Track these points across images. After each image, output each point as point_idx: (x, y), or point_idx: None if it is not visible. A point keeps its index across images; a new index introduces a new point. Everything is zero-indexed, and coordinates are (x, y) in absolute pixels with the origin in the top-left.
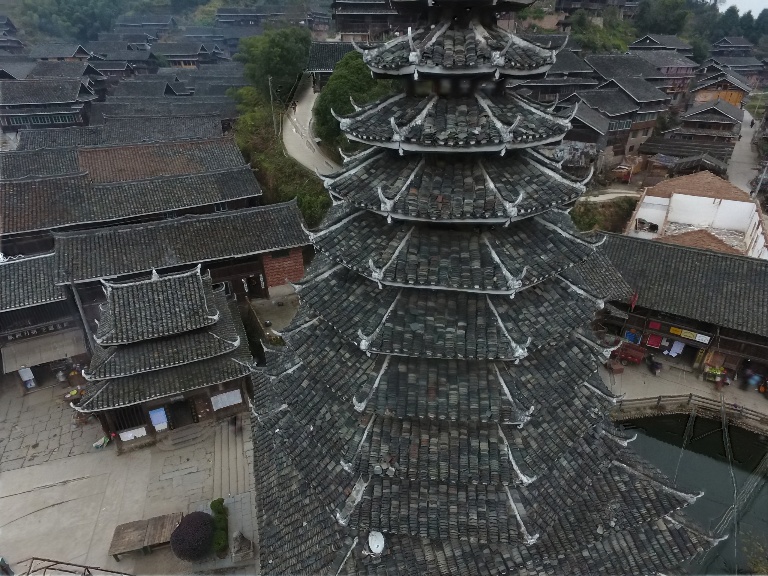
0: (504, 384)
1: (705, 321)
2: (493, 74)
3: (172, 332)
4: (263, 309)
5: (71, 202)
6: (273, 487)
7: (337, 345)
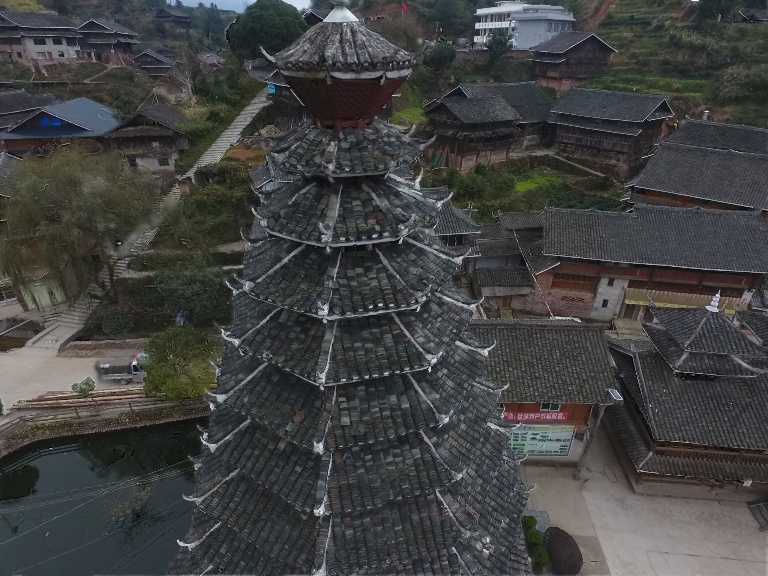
0: None
1: None
2: None
3: None
4: None
5: None
6: None
7: None
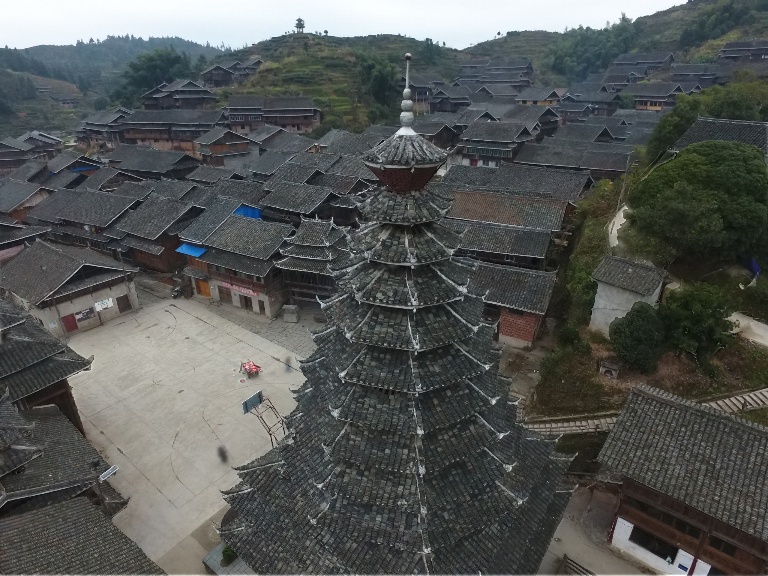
0: None
1: None
2: None
3: None
4: None
5: None
6: None
7: None
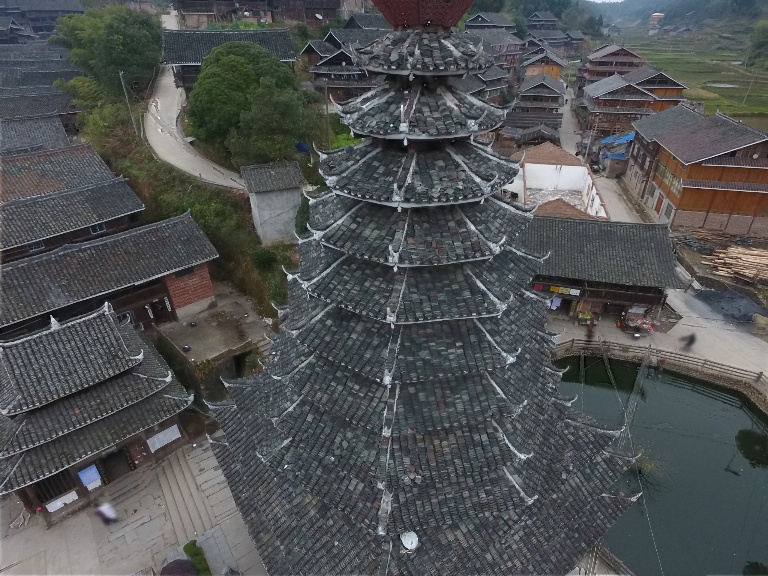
0: (496, 385)
1: (576, 278)
2: (469, 137)
3: (92, 383)
4: (175, 333)
5: None
6: (280, 517)
7: (343, 379)
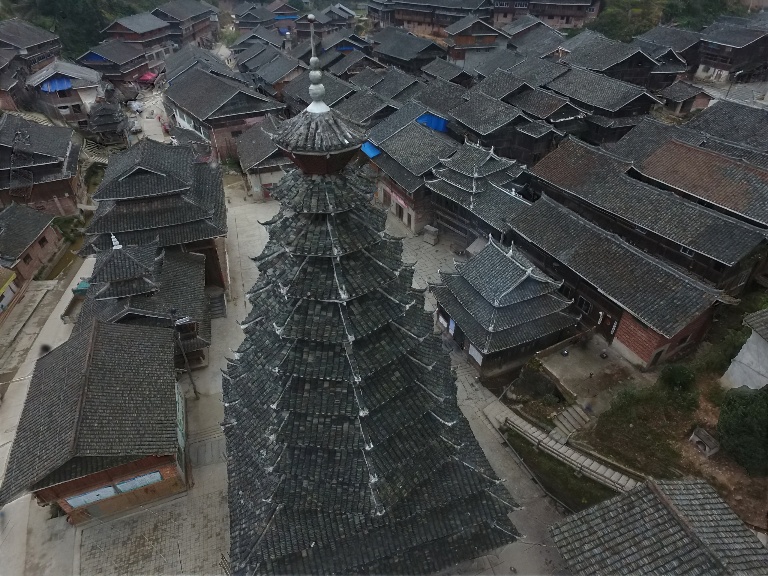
0: None
1: None
2: None
3: (477, 289)
4: (590, 345)
5: (594, 179)
6: None
7: None
